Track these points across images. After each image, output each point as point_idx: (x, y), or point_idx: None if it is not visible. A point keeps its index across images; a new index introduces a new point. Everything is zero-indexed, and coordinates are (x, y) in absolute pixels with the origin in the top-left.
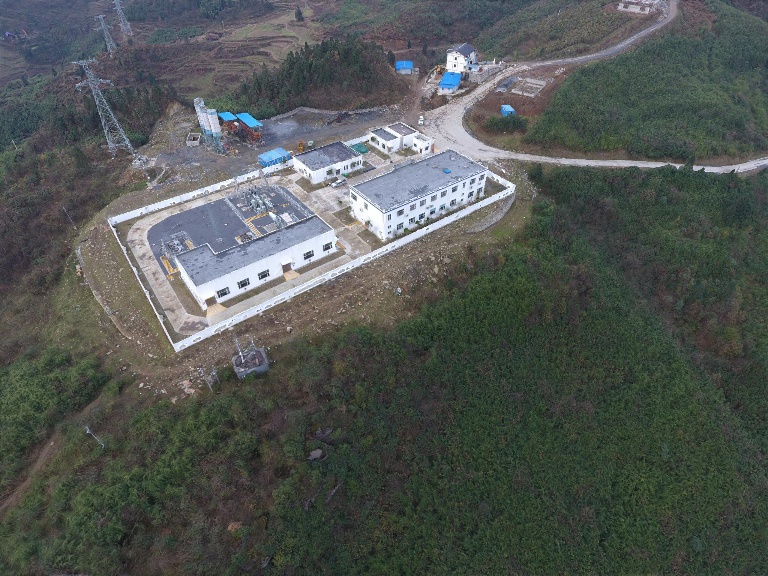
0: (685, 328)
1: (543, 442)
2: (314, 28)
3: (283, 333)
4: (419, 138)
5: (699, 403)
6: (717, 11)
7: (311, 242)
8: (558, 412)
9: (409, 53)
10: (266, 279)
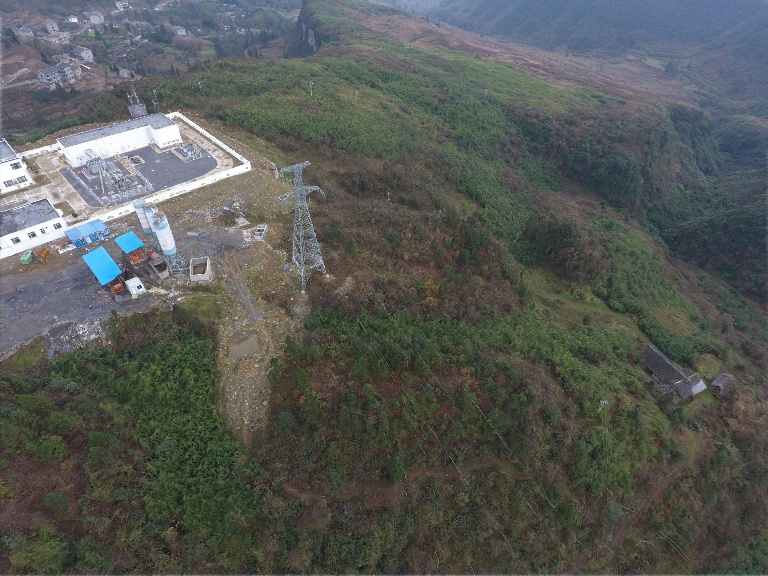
0: None
1: None
2: None
3: None
4: None
5: None
6: None
7: None
8: None
9: None
10: None
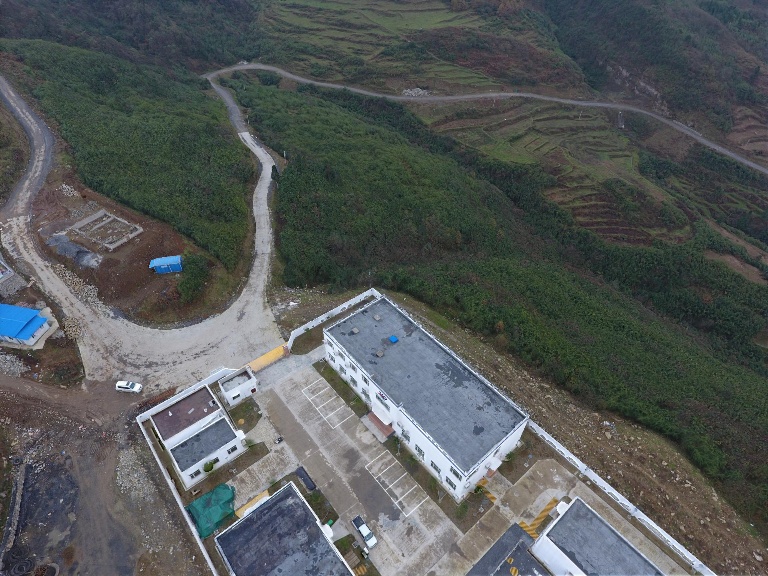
0: (443, 254)
1: None
2: None
3: (767, 566)
4: None
5: None
6: (1, 48)
7: None
8: None
9: None
10: None
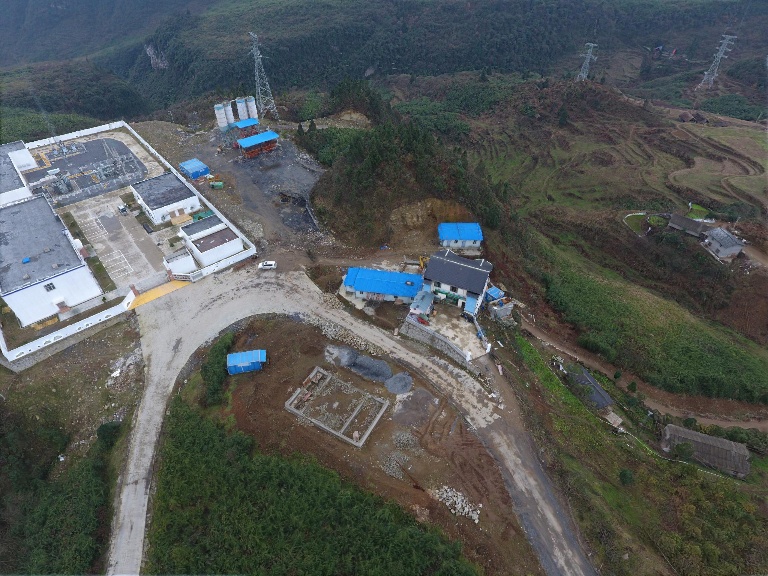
0: None
1: None
2: None
3: None
4: None
5: None
6: None
7: None
8: None
9: None
10: None
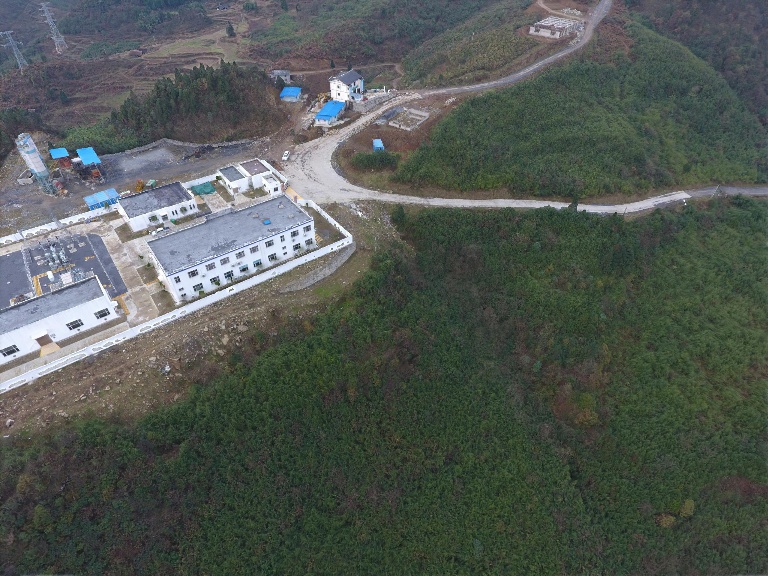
0: (542, 392)
1: (318, 548)
2: (242, 45)
3: (1, 427)
4: (270, 177)
5: (533, 486)
6: (635, 35)
7: (73, 311)
8: (351, 507)
9: (333, 73)
10: (16, 355)
